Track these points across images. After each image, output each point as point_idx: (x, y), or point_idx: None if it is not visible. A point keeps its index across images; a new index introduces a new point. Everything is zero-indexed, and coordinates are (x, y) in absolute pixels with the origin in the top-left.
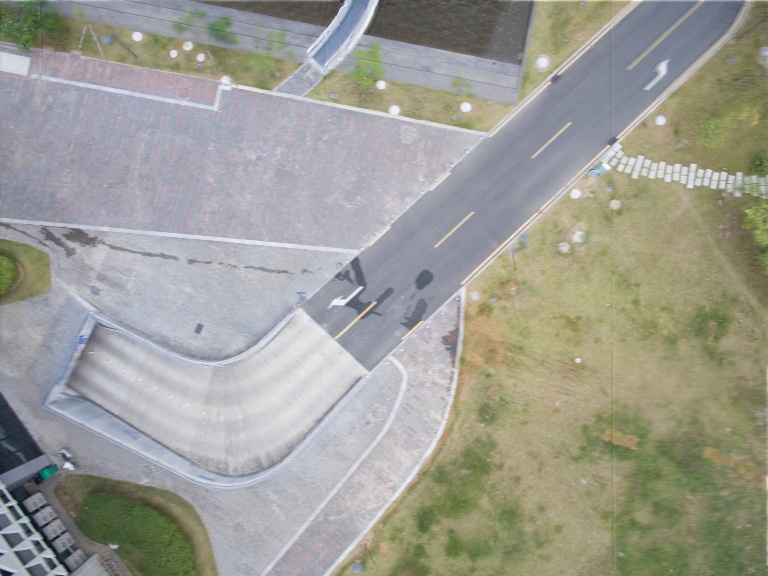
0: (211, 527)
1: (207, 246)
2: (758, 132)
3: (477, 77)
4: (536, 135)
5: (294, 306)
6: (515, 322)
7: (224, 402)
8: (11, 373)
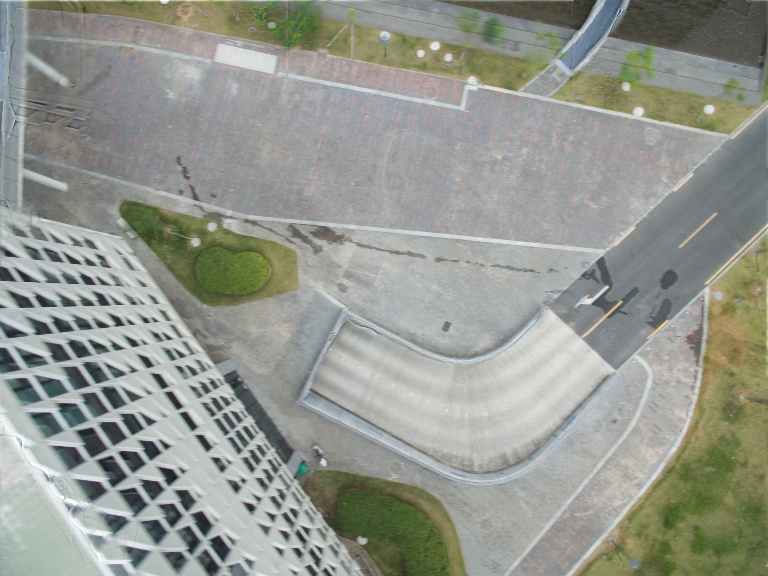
0: (459, 523)
1: (454, 245)
2: None
3: (719, 80)
4: None
5: (542, 305)
6: (758, 322)
7: (468, 399)
8: (259, 369)
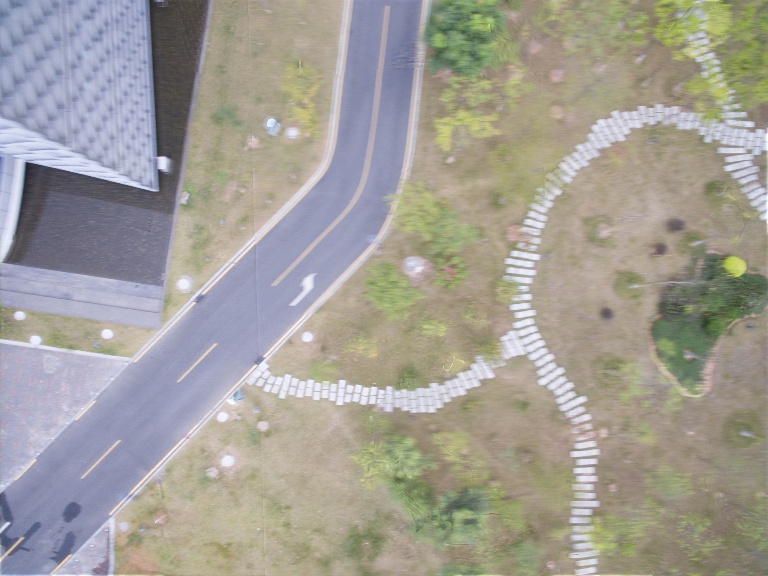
0: None
1: None
2: (406, 345)
3: (119, 302)
4: (181, 358)
5: None
6: (165, 551)
7: None
8: None
